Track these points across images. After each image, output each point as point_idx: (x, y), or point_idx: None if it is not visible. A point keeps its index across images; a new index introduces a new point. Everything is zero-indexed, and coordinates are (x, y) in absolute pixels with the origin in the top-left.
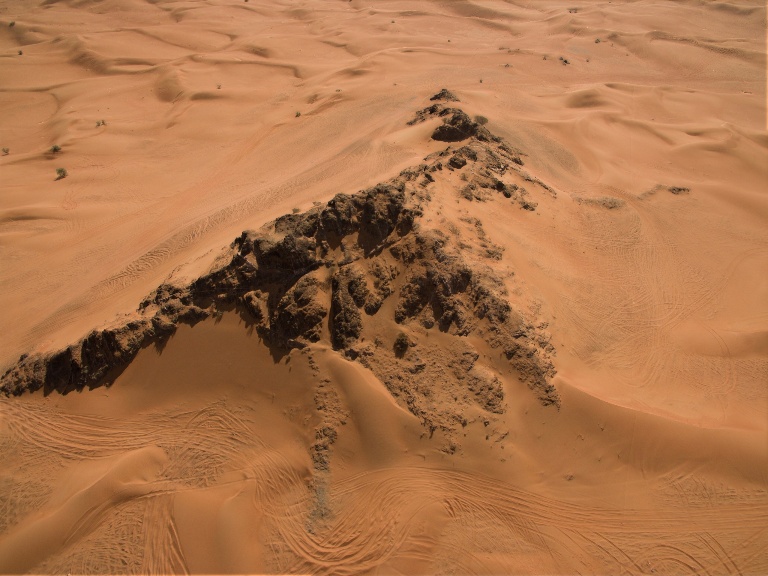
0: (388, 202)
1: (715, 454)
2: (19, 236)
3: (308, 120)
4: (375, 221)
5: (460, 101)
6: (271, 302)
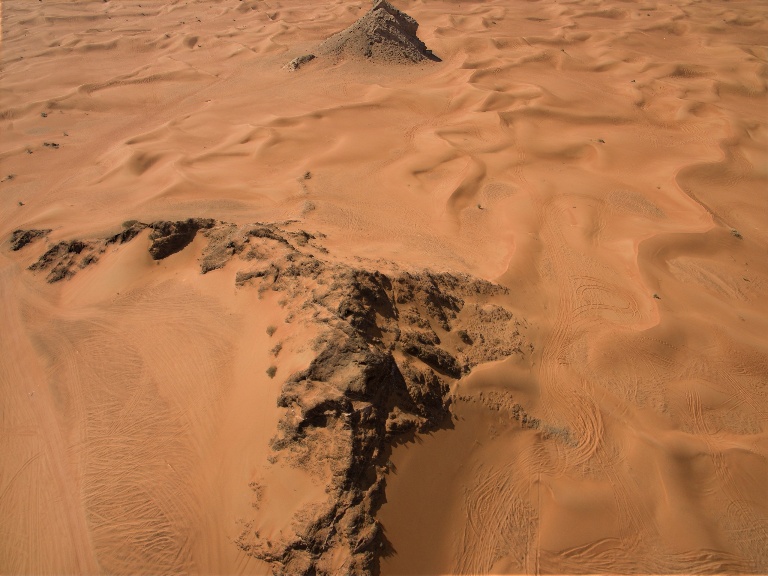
0: (367, 278)
1: (530, 254)
2: None
3: None
4: (378, 295)
5: (52, 230)
6: (406, 407)
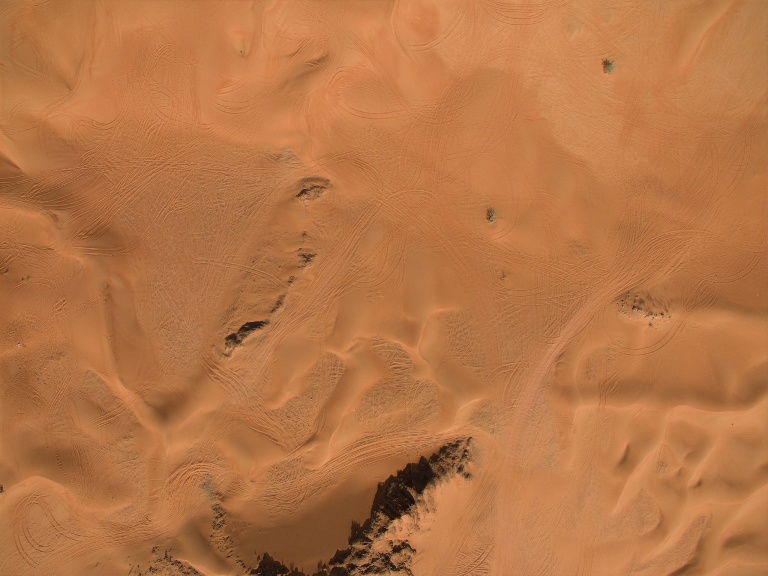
0: None
1: None
2: (646, 551)
3: None
4: None
5: None
6: None
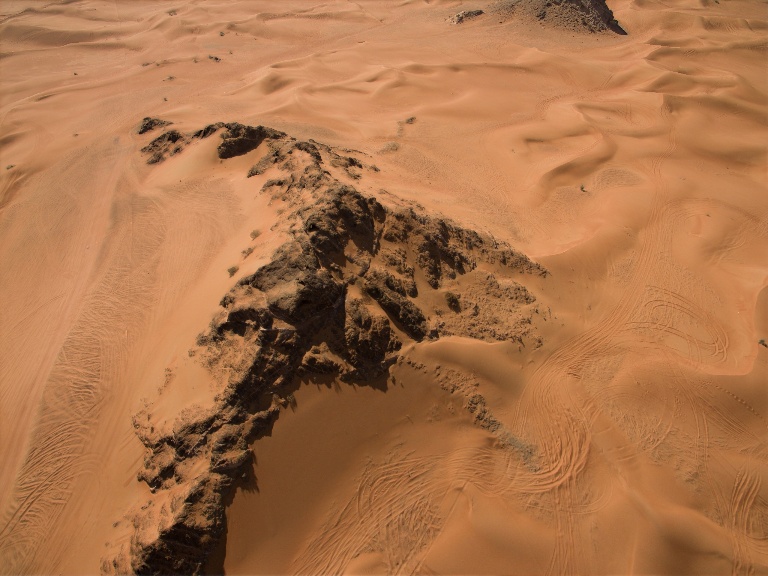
0: (355, 200)
1: (609, 247)
2: None
3: (5, 215)
4: (359, 221)
5: (173, 123)
6: (336, 347)
